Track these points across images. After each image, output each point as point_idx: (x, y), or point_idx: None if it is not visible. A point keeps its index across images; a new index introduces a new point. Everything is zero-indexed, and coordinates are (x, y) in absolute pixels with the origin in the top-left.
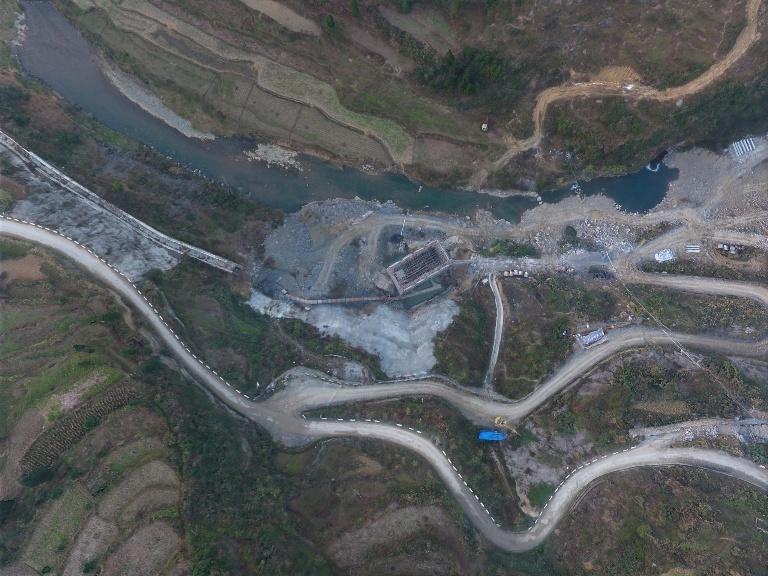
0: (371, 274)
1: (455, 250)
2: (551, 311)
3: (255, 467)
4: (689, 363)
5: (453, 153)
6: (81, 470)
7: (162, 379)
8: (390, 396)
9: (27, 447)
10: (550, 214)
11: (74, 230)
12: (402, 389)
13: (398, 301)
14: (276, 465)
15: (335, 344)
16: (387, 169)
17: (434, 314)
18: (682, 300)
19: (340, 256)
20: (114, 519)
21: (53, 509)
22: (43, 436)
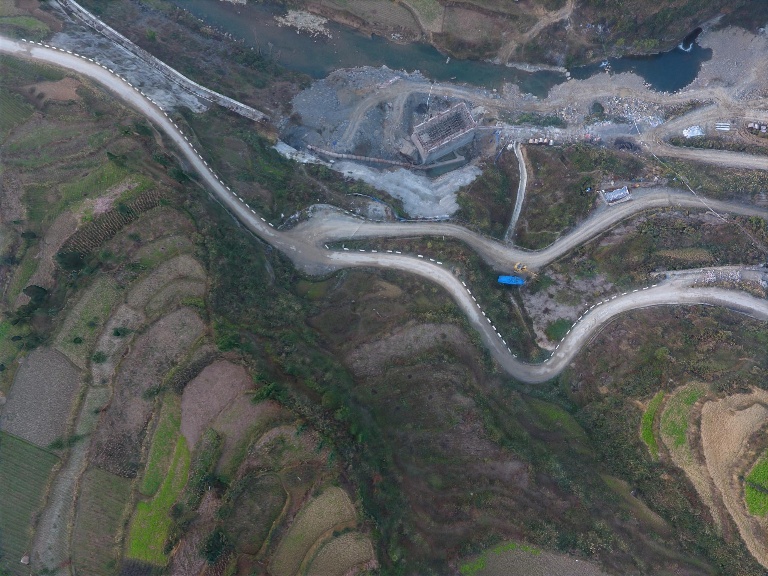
0: (396, 140)
1: (480, 121)
2: (575, 172)
3: (277, 287)
4: (714, 219)
5: (483, 23)
6: (111, 266)
7: (191, 190)
8: (412, 235)
9: (60, 244)
10: (578, 90)
11: (109, 61)
12: (424, 229)
13: (421, 170)
14: (297, 291)
15: (359, 184)
16: (416, 39)
17: (457, 174)
18: (709, 170)
19: (366, 116)
20: (142, 308)
21: (84, 299)
22: (76, 234)
